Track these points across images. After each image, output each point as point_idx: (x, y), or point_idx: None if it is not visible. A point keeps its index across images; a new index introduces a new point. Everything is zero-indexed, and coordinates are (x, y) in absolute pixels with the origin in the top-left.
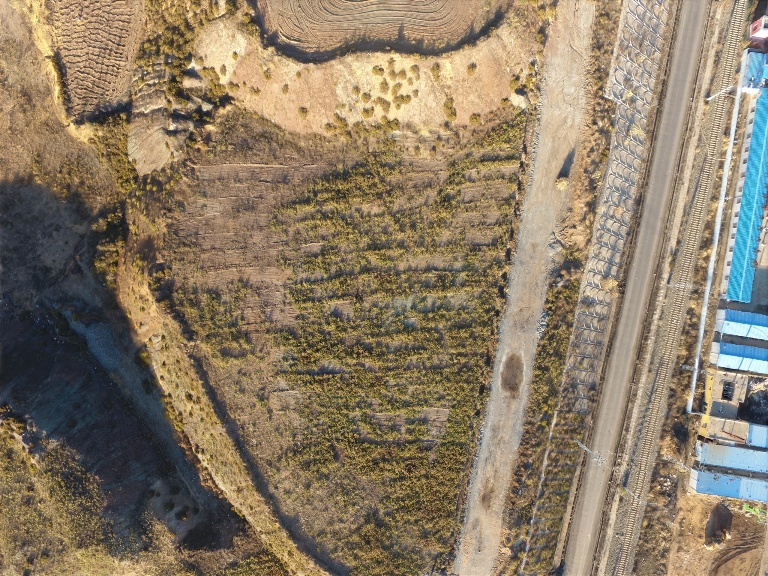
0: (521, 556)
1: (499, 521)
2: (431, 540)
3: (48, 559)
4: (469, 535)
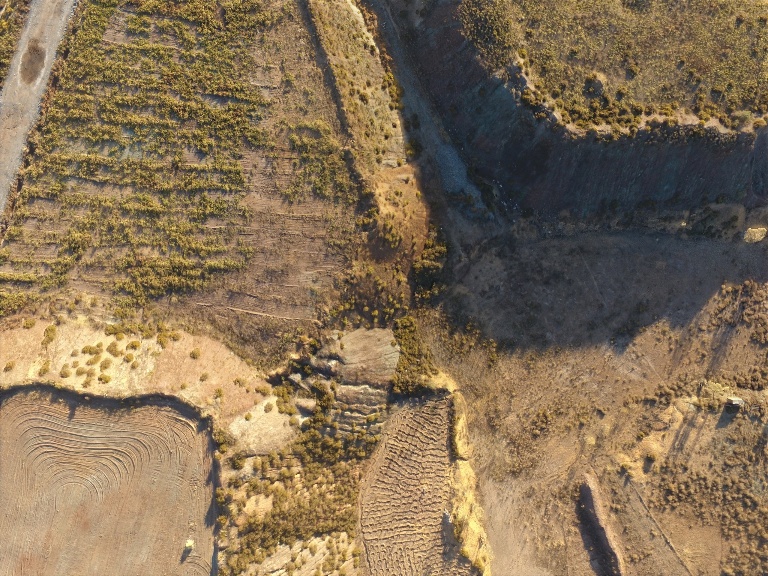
0: None
1: None
2: None
3: None
4: None
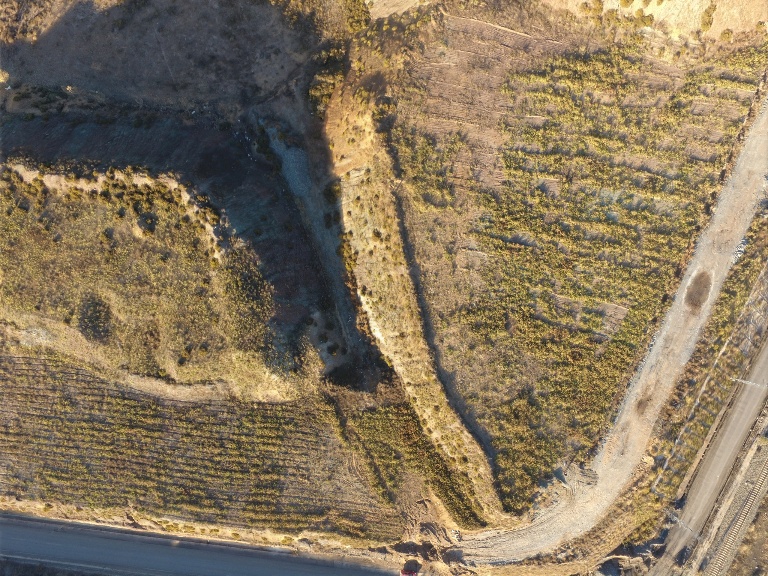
0: (658, 472)
1: (649, 430)
2: (578, 431)
3: (205, 353)
4: (616, 436)
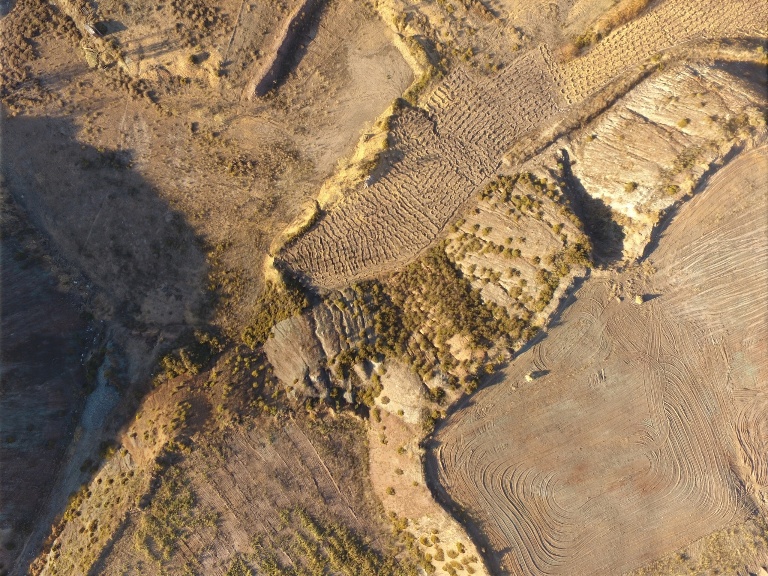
0: None
1: None
2: None
3: None
4: None
